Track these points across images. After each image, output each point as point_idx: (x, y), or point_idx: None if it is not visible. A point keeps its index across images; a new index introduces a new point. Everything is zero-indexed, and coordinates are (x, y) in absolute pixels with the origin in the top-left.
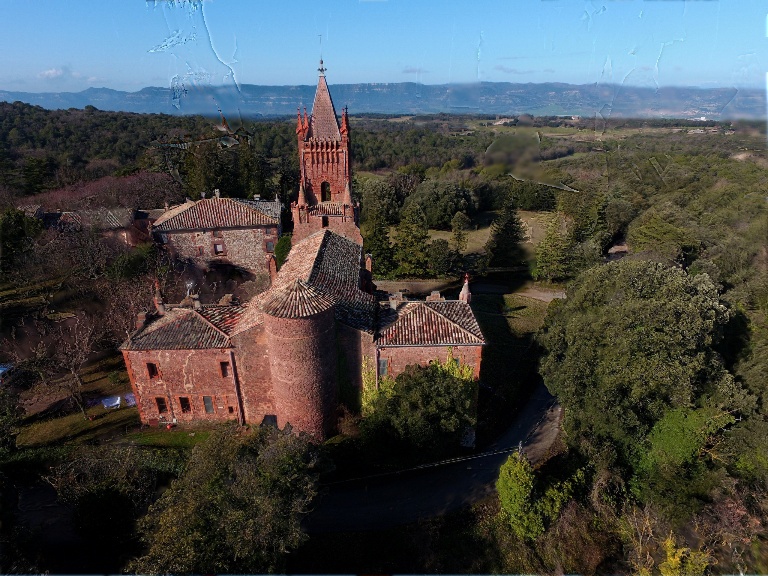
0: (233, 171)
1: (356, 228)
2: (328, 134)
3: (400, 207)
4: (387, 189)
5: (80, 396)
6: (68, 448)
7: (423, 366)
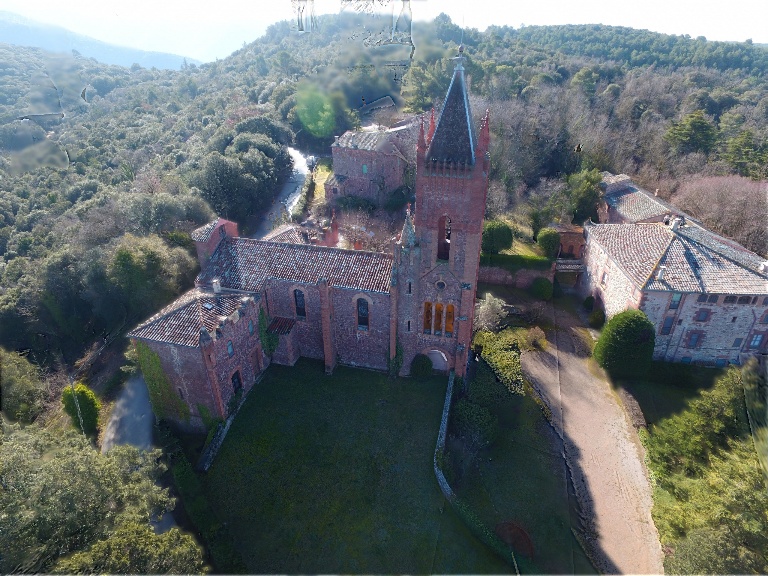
0: None
1: None
2: None
3: None
4: None
5: None
6: None
7: None
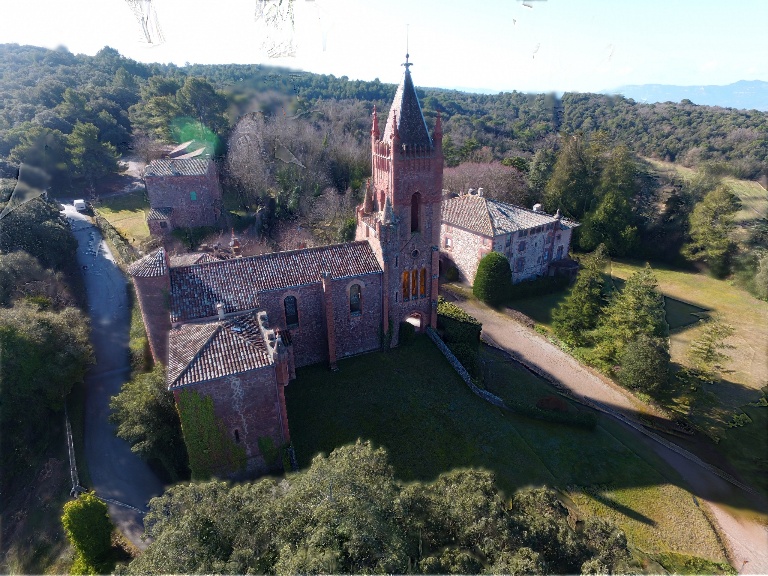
0: (595, 178)
1: (381, 248)
2: None
3: None
4: None
5: None
6: None
7: None
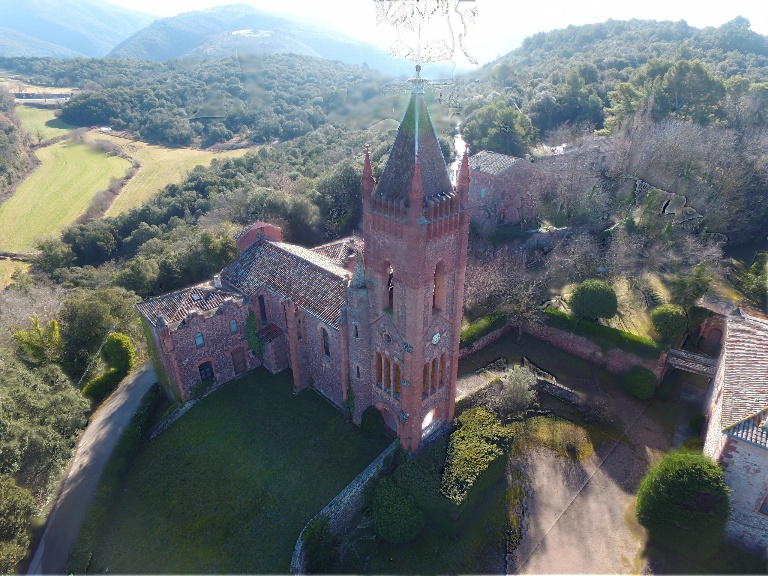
0: None
1: None
2: None
3: None
4: None
5: None
6: None
7: None
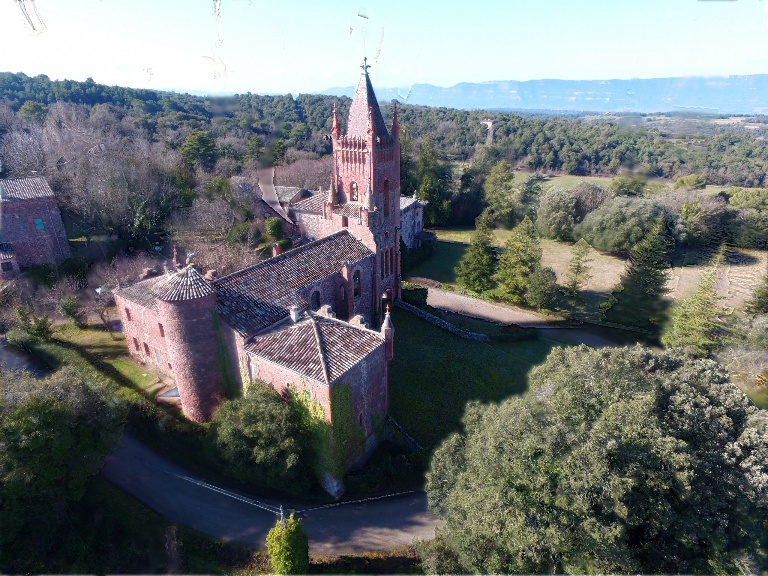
0: (411, 164)
1: (370, 233)
2: (360, 133)
3: (577, 223)
4: (565, 200)
5: (108, 320)
6: (68, 352)
7: (284, 387)
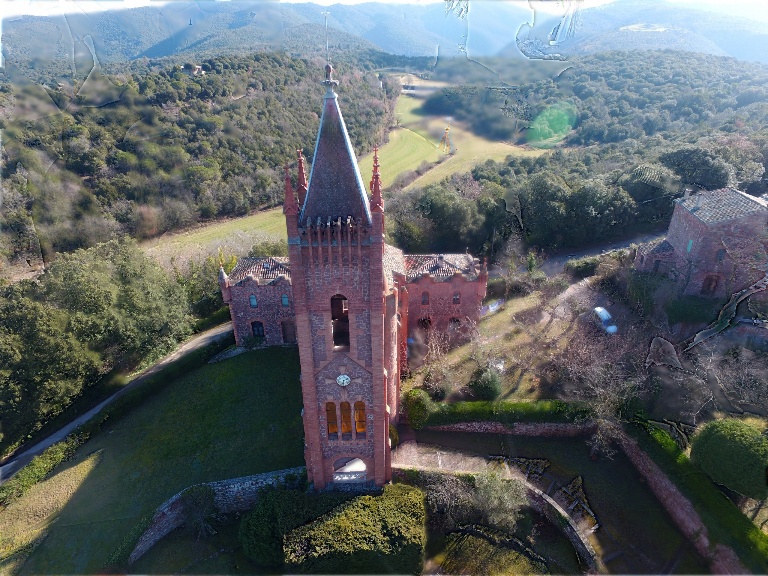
0: None
1: None
2: None
3: None
4: None
5: None
6: None
7: None
